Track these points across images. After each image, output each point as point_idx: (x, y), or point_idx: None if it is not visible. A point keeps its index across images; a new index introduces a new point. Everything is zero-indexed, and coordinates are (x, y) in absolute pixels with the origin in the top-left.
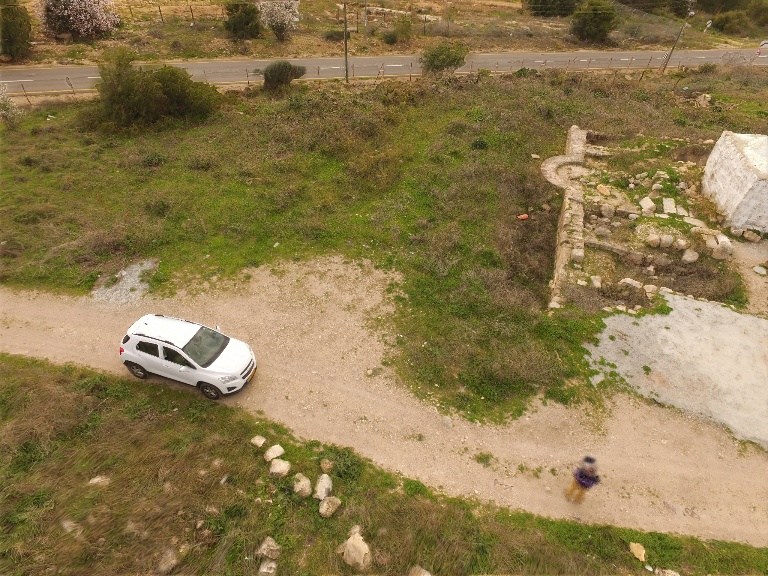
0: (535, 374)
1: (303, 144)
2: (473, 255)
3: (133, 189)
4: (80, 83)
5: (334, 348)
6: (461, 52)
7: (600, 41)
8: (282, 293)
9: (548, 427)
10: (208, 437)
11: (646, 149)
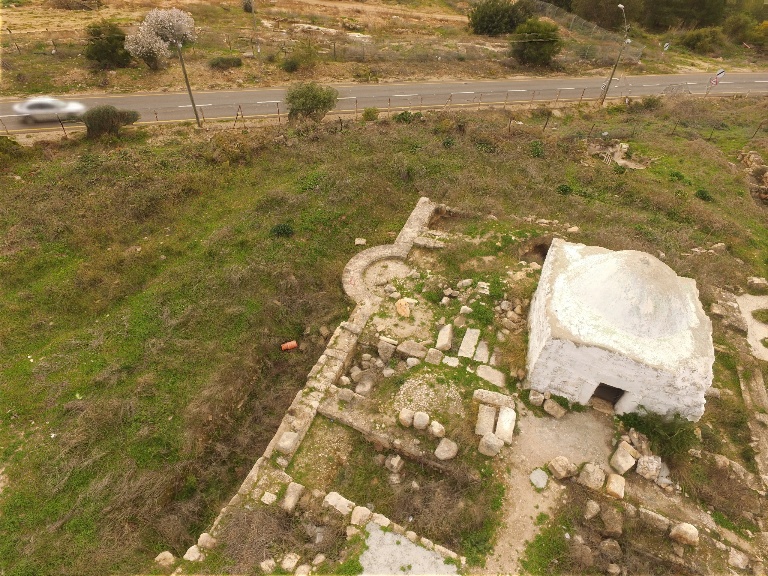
0: None
1: None
2: (135, 442)
3: None
4: None
5: None
6: (332, 92)
7: (544, 64)
8: None
9: None
10: None
11: (488, 240)
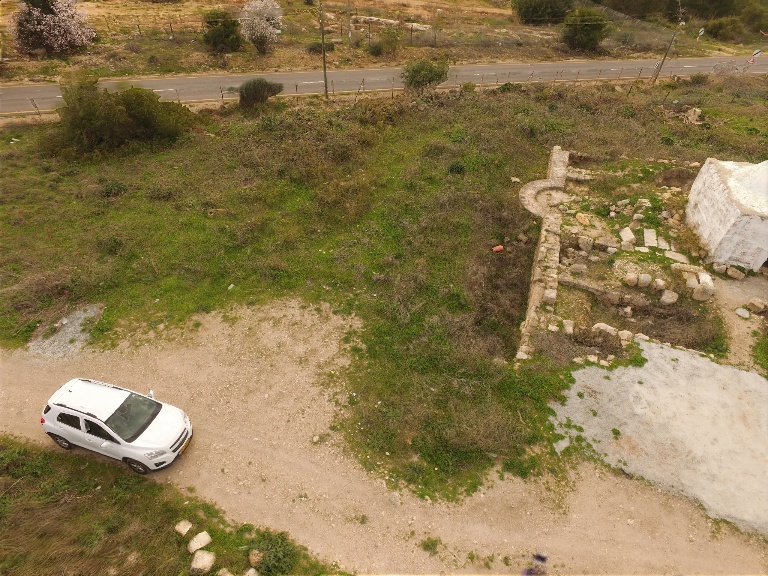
0: (492, 443)
1: (272, 170)
2: (439, 297)
3: (87, 223)
4: (49, 103)
5: (280, 409)
6: (444, 67)
7: (591, 49)
8: (231, 344)
9: (504, 506)
10: (127, 525)
11: (629, 173)
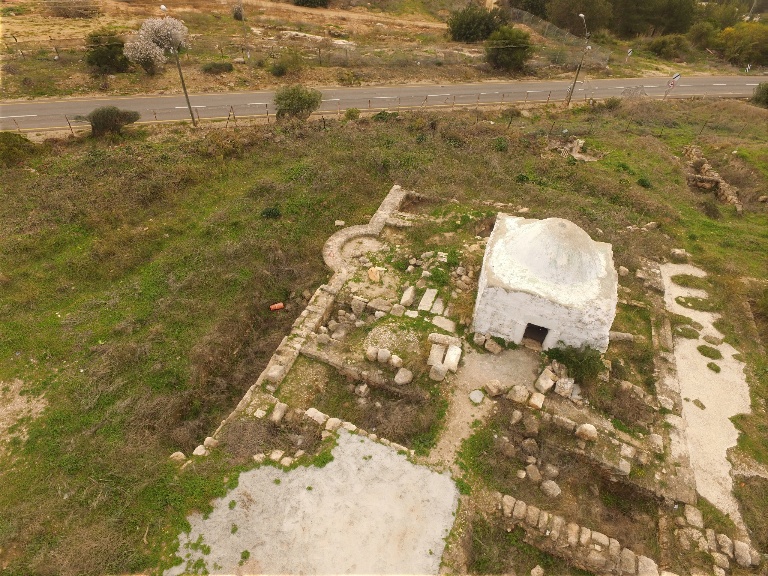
0: None
1: None
2: (150, 374)
3: None
4: None
5: None
6: (316, 94)
7: (517, 69)
8: None
9: None
10: None
11: (449, 220)
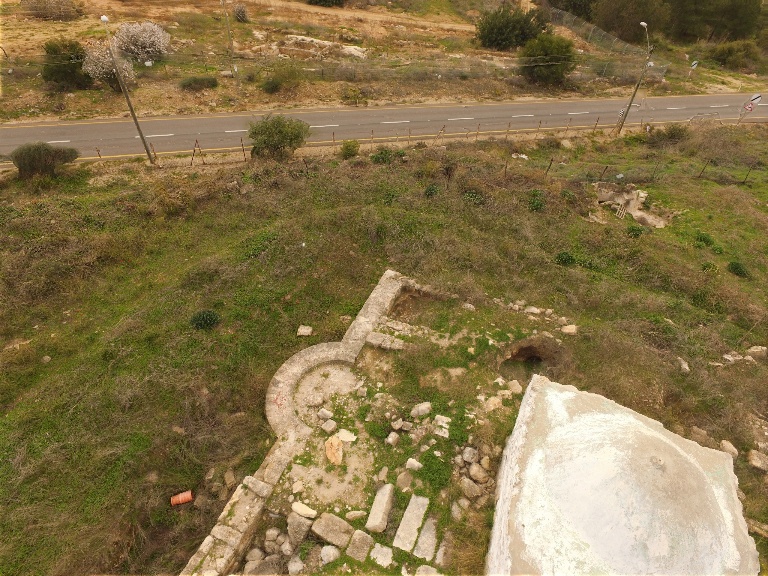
0: None
1: None
2: None
3: None
4: None
5: None
6: (301, 127)
7: (557, 83)
8: None
9: None
10: None
11: (458, 343)
